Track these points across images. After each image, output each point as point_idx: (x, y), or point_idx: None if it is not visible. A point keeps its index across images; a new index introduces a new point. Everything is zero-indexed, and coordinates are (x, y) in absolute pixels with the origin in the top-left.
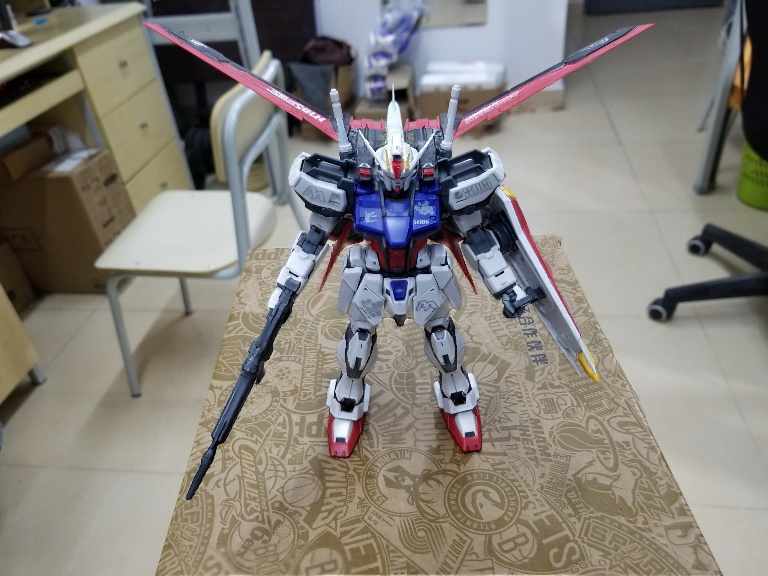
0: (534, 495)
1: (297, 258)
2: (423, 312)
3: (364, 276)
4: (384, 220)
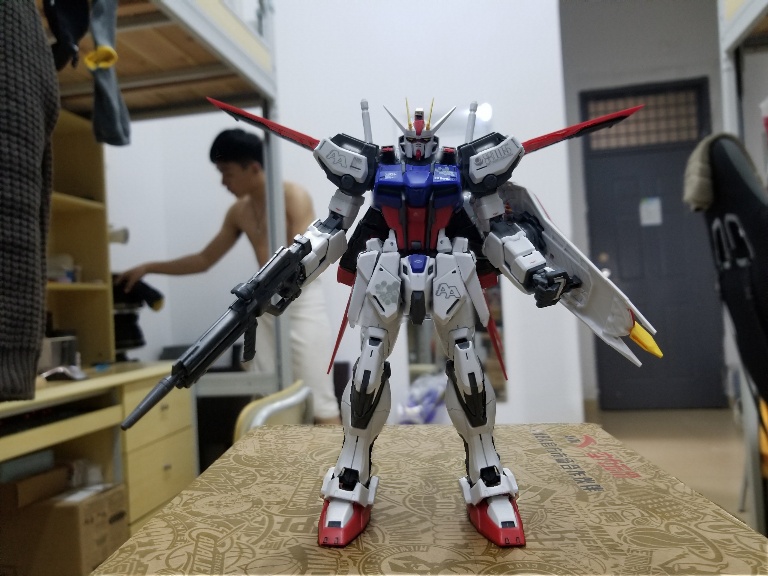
0: None
1: (311, 235)
2: (444, 300)
3: (380, 256)
4: (404, 174)
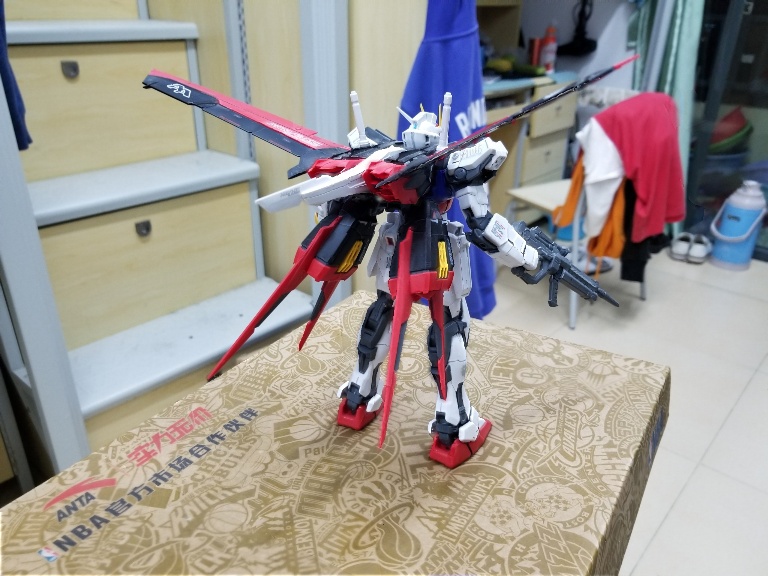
0: None
1: None
2: None
3: None
4: None
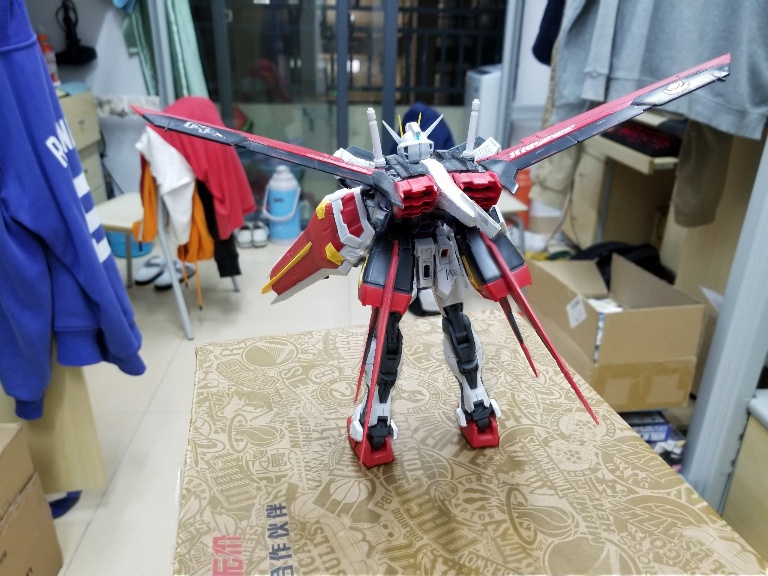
0: (306, 397)
1: None
2: None
3: None
4: None
